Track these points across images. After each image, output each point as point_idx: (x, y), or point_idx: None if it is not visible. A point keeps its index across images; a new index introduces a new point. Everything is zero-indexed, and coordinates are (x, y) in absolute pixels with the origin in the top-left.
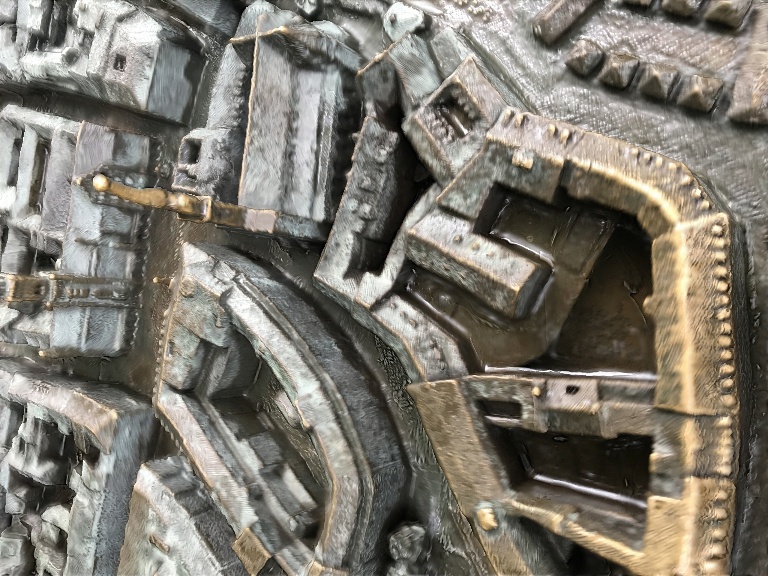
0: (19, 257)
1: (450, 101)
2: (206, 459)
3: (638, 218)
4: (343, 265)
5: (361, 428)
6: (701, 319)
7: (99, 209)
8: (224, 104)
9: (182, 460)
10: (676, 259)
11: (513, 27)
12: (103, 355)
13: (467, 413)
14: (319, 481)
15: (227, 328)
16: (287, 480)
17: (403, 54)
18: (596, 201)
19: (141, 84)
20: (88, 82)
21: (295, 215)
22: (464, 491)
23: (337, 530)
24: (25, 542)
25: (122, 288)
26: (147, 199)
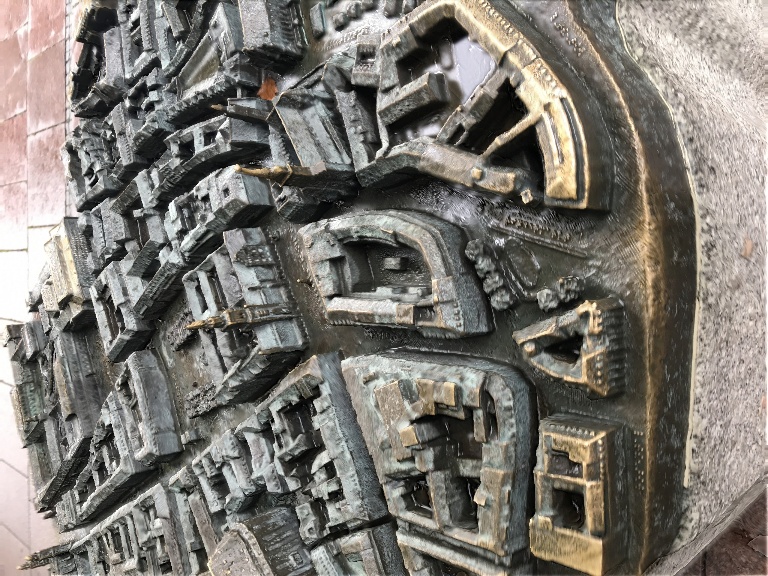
0: (226, 339)
1: (362, 56)
2: (363, 306)
3: (445, 16)
4: (365, 158)
5: (419, 218)
6: (485, 20)
7: (252, 270)
8: (281, 162)
9: (363, 354)
10: (463, 12)
11: (379, 24)
12: (295, 349)
13: (444, 148)
14: (429, 284)
15: (338, 244)
16: (411, 292)
17: (335, 60)
18: (430, 27)
19: (241, 193)
20: (217, 221)
21: (335, 163)
22: (463, 176)
23: (433, 261)
24: (311, 503)
25: (286, 307)
26: (260, 171)
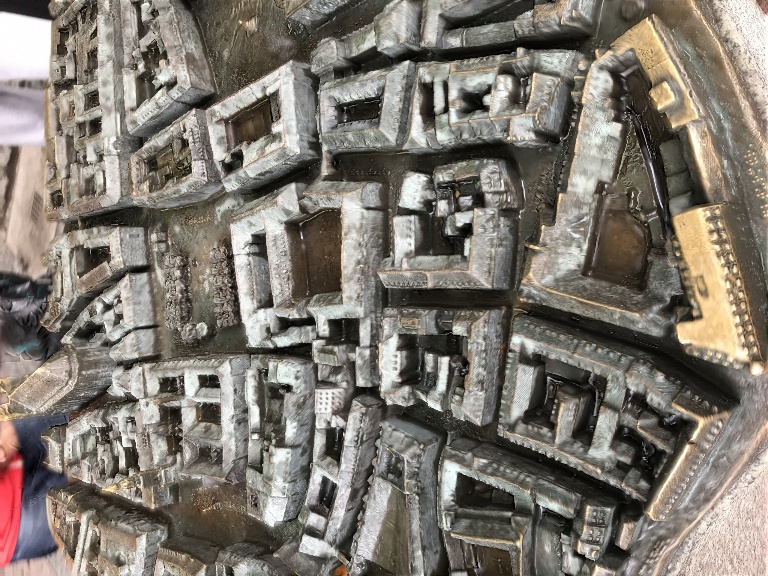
0: None
1: None
2: None
3: None
4: None
5: None
6: None
7: None
8: None
9: None
10: None
11: None
12: None
13: None
14: None
15: None
16: None
17: None
18: None
19: None
20: None
21: None
22: None
23: None
24: None
25: None
26: None
